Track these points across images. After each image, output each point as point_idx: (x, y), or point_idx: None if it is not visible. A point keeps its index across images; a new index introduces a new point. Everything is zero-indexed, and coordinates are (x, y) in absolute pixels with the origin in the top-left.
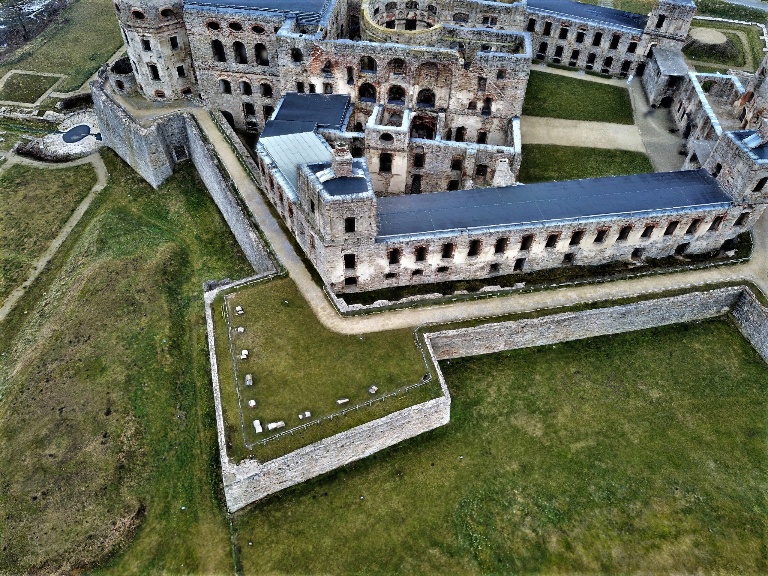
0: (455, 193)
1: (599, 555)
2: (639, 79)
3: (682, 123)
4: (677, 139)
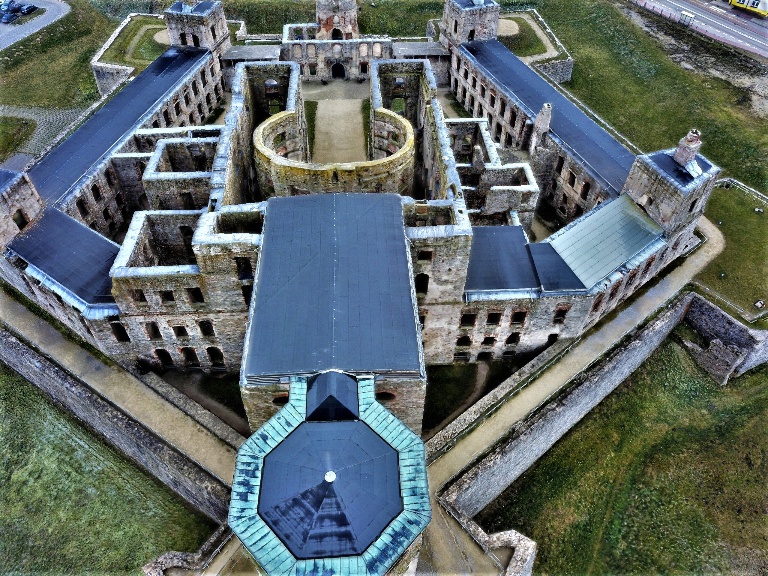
0: (575, 148)
1: (760, 134)
2: (227, 92)
3: (322, 73)
4: (337, 82)
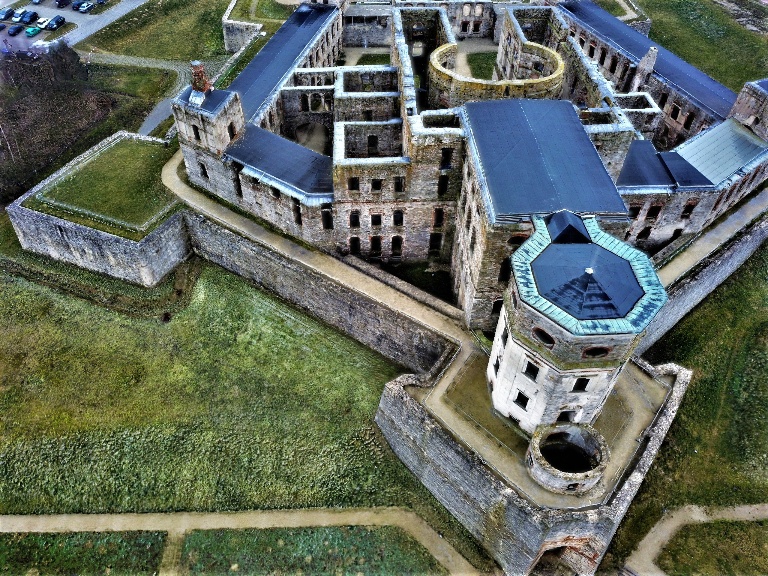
0: (679, 84)
1: None
2: (344, 47)
3: None
4: None
